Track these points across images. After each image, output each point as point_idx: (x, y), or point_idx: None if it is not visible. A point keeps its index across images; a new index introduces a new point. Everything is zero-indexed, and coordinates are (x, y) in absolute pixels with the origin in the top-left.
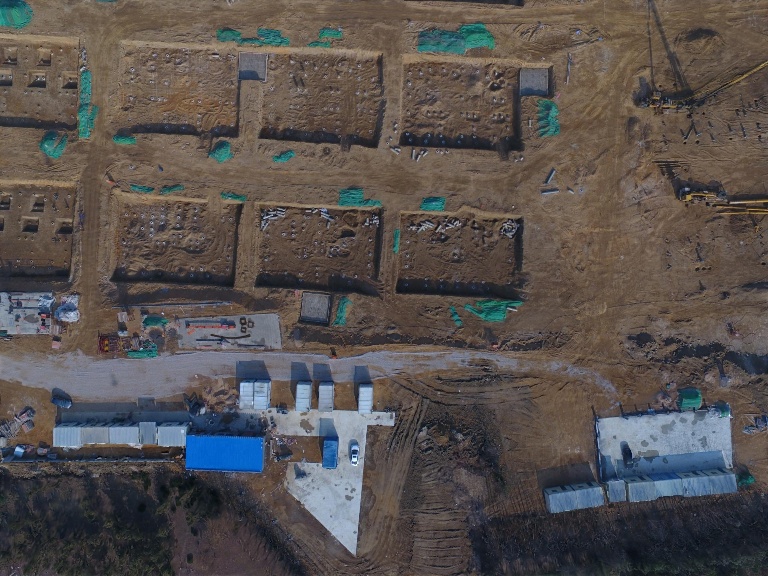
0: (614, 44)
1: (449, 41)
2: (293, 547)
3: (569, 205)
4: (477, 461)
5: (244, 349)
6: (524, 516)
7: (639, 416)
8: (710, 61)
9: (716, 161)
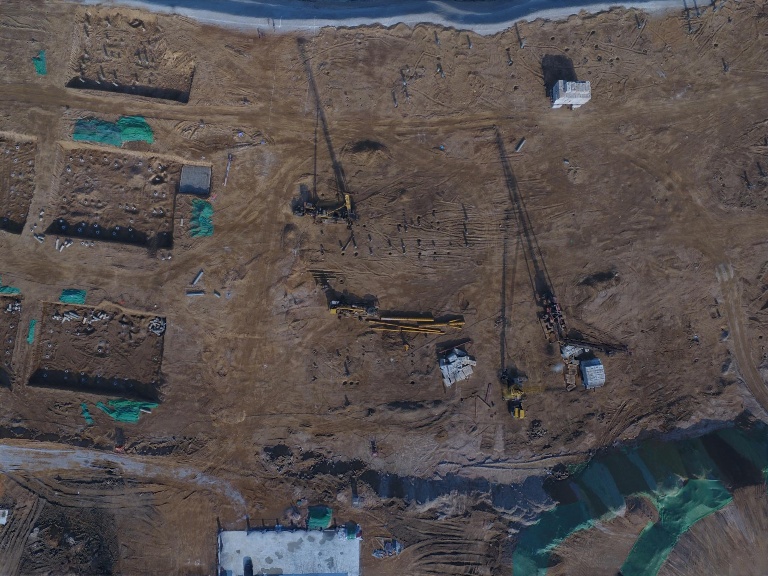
0: (277, 149)
1: (105, 132)
2: None
3: (215, 308)
4: (89, 567)
5: None
6: None
7: (262, 532)
8: (375, 174)
9: (373, 275)
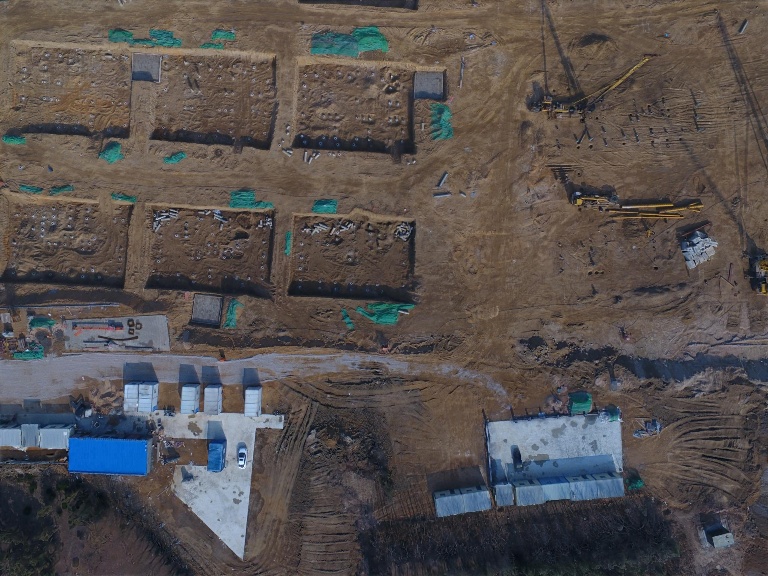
0: (507, 48)
1: (342, 44)
2: (180, 551)
3: (461, 208)
4: (366, 464)
5: (132, 351)
6: (413, 520)
7: (529, 420)
8: (604, 66)
9: (609, 166)
